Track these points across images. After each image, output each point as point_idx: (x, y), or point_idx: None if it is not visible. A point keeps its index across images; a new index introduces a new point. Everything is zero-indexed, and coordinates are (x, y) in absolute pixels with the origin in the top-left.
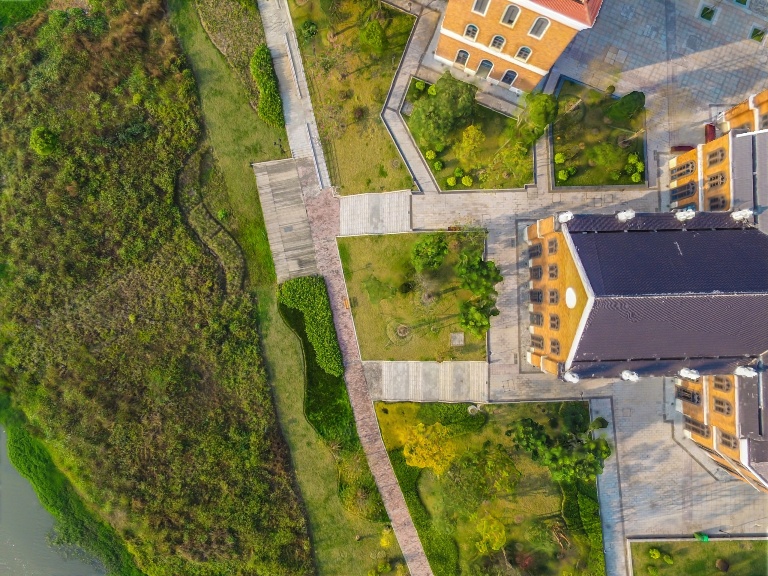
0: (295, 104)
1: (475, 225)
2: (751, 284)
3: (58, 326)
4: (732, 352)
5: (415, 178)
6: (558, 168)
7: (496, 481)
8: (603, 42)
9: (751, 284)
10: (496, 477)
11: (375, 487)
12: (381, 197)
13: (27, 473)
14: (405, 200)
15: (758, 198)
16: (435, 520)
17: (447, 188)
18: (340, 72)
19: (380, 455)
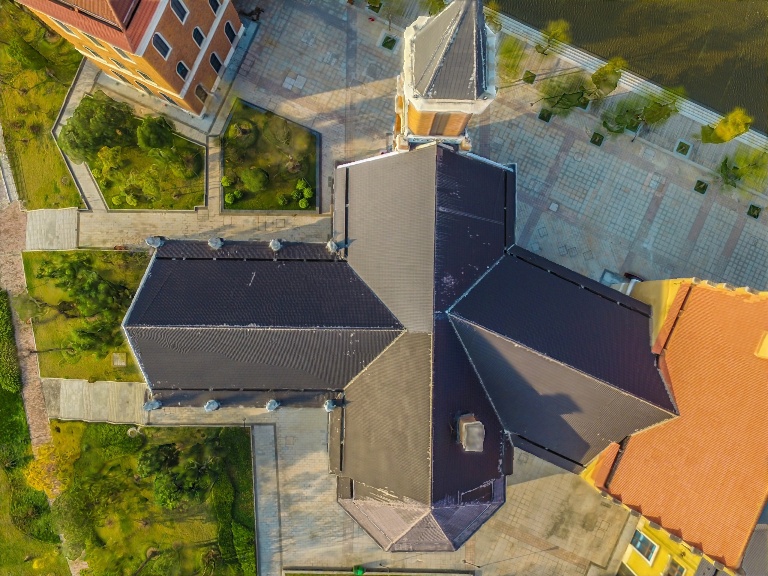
0: None
1: (143, 245)
2: (294, 318)
3: None
4: (312, 385)
5: (84, 196)
6: (227, 191)
7: (101, 508)
8: (282, 67)
9: (294, 318)
10: (101, 503)
11: (47, 507)
12: (58, 213)
13: None
14: (73, 217)
15: (348, 230)
16: (62, 545)
17: (115, 207)
18: (22, 87)
19: None
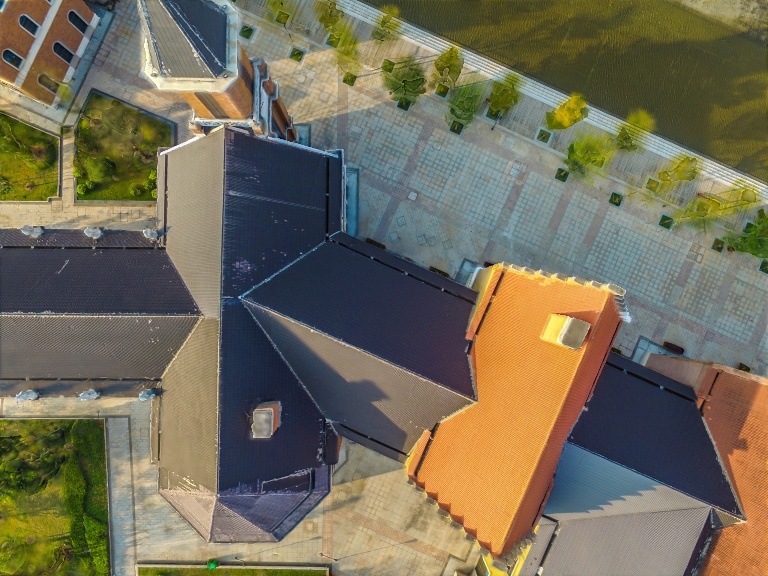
0: None
1: None
2: (92, 305)
3: None
4: (128, 374)
5: None
6: (80, 182)
7: None
8: (137, 57)
9: (92, 305)
10: None
11: None
12: None
13: None
14: None
15: (167, 218)
16: None
17: None
18: None
19: None
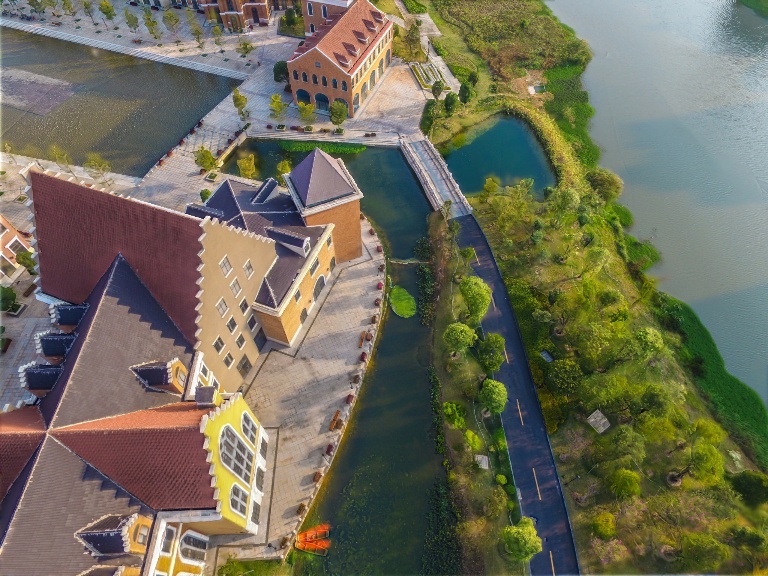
0: (427, 46)
1: None
2: None
3: (510, 4)
4: None
5: None
6: None
7: None
8: None
9: None
10: None
11: None
12: None
13: None
14: None
15: None
16: None
17: None
18: None
19: None
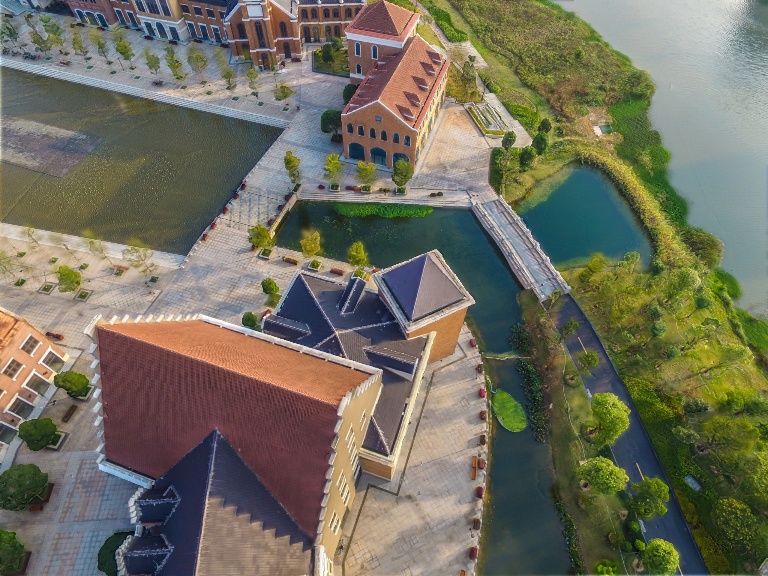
0: (476, 81)
1: None
2: None
3: None
4: None
5: None
6: None
7: None
8: None
9: None
10: None
11: None
12: None
13: (552, 2)
14: None
15: None
16: None
17: None
18: None
19: (417, 6)
